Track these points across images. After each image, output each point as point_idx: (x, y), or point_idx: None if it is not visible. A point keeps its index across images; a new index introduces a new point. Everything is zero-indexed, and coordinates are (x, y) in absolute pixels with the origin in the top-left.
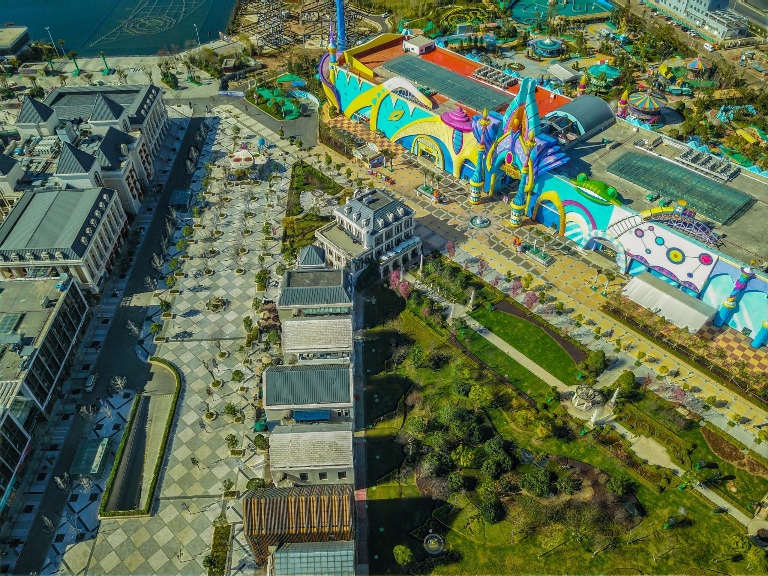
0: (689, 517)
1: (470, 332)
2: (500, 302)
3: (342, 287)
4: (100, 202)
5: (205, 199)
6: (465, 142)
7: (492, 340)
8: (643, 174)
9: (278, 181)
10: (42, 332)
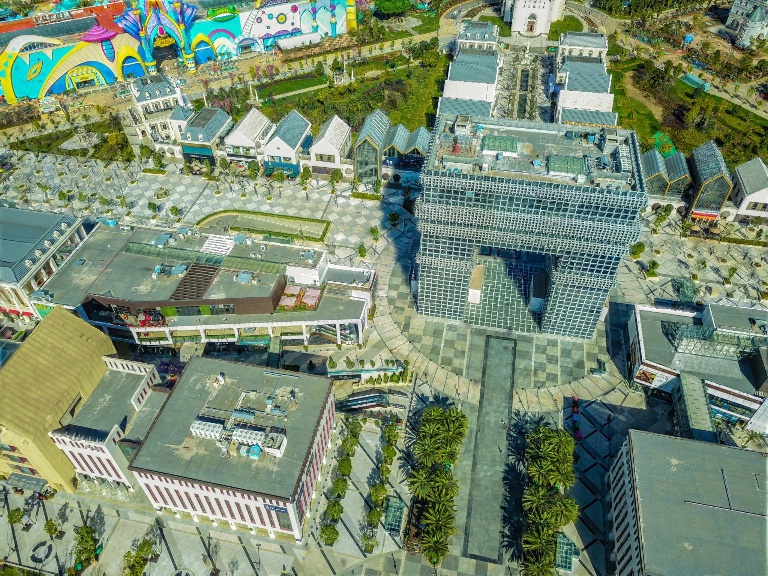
0: (408, 74)
1: (271, 102)
2: (256, 88)
3: (221, 109)
4: (3, 204)
5: (6, 199)
6: (116, 47)
7: (282, 96)
8: (221, 1)
9: (26, 158)
10: (162, 230)
